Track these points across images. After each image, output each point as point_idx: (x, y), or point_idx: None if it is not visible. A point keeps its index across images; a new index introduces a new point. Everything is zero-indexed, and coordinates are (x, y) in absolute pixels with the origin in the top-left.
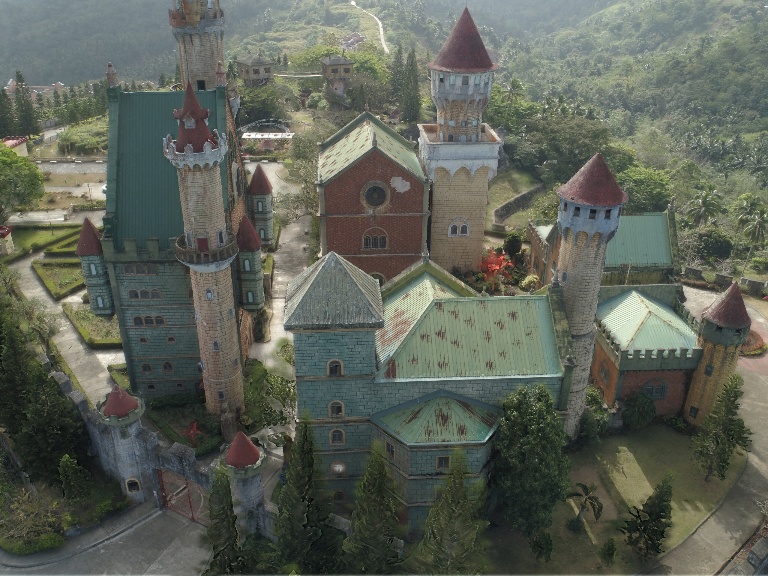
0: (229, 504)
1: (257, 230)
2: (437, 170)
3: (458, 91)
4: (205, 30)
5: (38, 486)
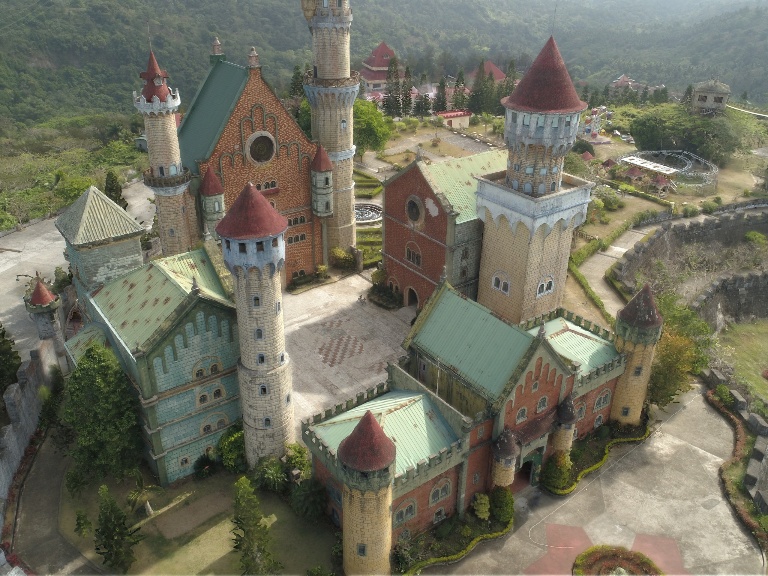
0: None
1: (313, 200)
2: (488, 210)
3: (509, 128)
4: (318, 25)
5: None
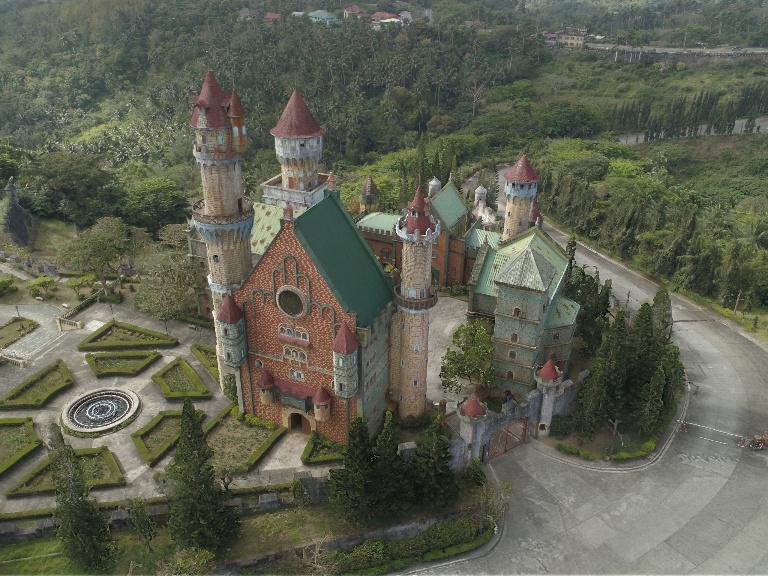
0: (538, 413)
1: None
2: None
3: (316, 149)
4: None
5: (434, 516)
